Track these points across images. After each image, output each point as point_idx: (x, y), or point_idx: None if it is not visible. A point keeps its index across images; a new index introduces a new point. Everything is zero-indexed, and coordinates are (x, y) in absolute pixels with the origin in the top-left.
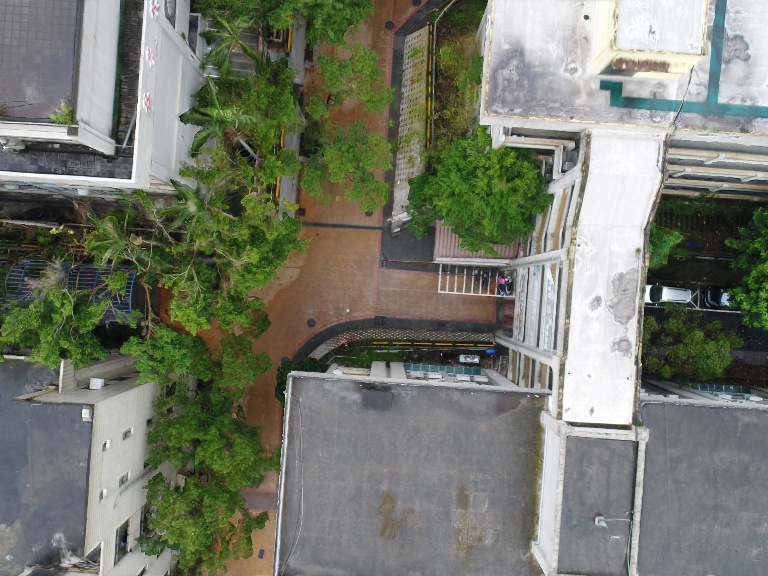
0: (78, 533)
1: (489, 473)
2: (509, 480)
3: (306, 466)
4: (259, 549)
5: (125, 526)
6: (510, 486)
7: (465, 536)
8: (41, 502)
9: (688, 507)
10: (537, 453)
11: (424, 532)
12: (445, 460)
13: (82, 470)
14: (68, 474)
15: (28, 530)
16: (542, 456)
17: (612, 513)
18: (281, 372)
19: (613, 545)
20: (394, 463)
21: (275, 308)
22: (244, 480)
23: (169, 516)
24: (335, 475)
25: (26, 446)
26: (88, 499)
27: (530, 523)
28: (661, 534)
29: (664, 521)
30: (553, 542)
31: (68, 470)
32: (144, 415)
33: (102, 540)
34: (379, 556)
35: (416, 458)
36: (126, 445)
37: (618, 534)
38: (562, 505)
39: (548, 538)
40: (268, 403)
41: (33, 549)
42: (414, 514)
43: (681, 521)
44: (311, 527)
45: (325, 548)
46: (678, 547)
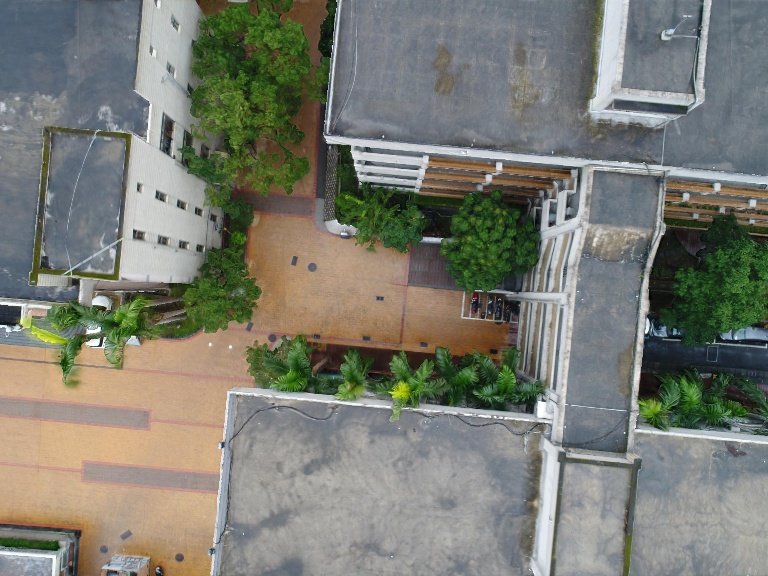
0: (125, 107)
1: (548, 29)
2: (568, 37)
3: (361, 18)
4: (292, 256)
5: (169, 134)
6: (569, 43)
7: (521, 94)
8: (88, 74)
9: (751, 69)
10: (597, 10)
11: (480, 88)
12: (503, 15)
13: (130, 43)
14: (116, 47)
15: (74, 102)
16: (602, 13)
17: (679, 29)
18: (328, 4)
19: (679, 62)
20: (451, 16)
21: (315, 4)
22: (293, 70)
23: (217, 92)
24: (390, 27)
25: (74, 17)
26: (140, 30)
27: (588, 82)
28: (723, 96)
29: (726, 83)
30: (618, 55)
31: (116, 43)
32: (190, 29)
33: (150, 101)
34: (433, 112)
35: (473, 12)
36: (174, 34)
37: (684, 51)
38: (628, 17)
39: (611, 63)
40: (306, 104)
41: (79, 122)
42: (470, 69)
43: (743, 84)
44: (365, 80)
45: (378, 102)
46: (740, 110)
